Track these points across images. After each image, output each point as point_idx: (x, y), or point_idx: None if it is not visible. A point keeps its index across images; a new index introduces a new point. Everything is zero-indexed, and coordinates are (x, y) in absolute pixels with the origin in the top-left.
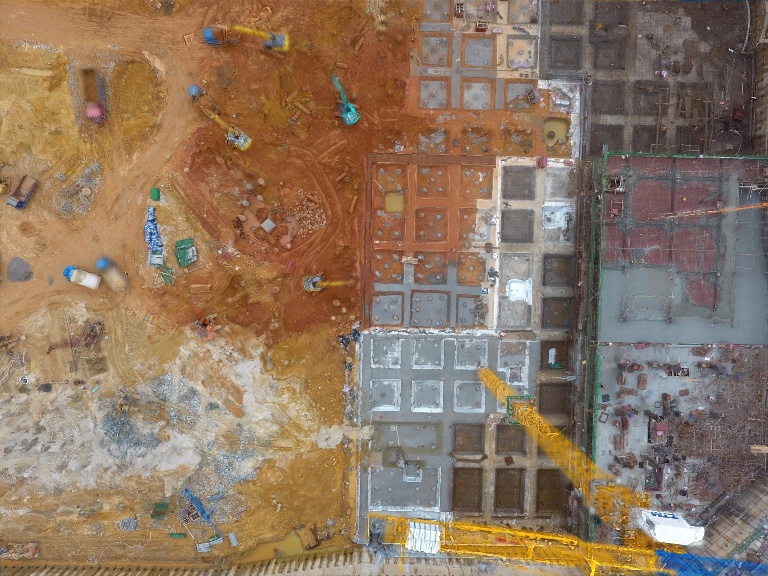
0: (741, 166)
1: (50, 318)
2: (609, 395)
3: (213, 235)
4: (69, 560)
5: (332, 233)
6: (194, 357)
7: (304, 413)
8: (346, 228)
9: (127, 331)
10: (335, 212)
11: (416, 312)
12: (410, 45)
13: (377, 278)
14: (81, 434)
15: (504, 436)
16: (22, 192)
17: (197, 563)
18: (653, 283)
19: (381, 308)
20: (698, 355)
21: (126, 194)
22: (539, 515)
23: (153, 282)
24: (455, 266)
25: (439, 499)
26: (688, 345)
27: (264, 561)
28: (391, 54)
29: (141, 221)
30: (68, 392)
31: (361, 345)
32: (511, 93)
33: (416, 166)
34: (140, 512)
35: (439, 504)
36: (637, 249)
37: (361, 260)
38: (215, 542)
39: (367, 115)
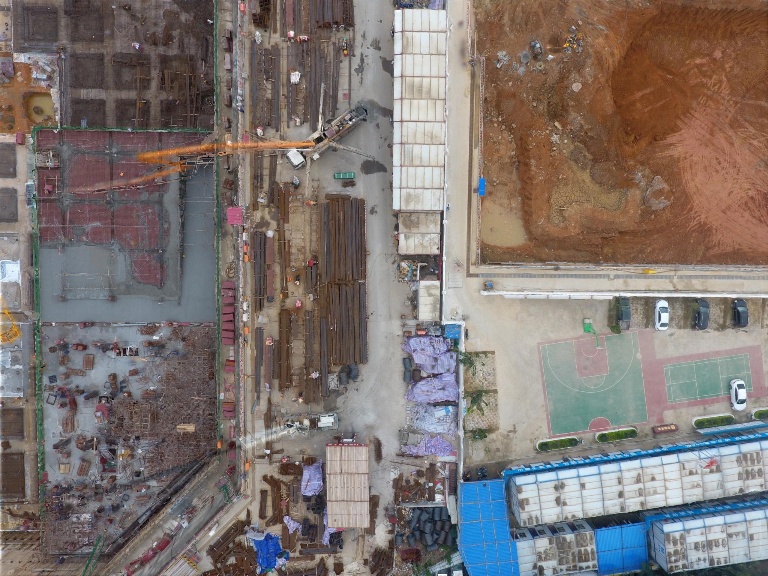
0: (181, 140)
1: None
2: (56, 376)
3: None
4: None
5: None
6: None
7: None
8: None
9: None
10: None
11: None
12: None
13: None
14: None
15: (3, 420)
16: None
17: None
18: (95, 261)
19: None
20: (146, 334)
21: None
22: None
23: None
24: None
25: None
26: (133, 324)
27: None
28: None
29: None
30: None
31: None
32: None
33: None
34: None
35: None
36: (76, 226)
37: None
38: None
39: None
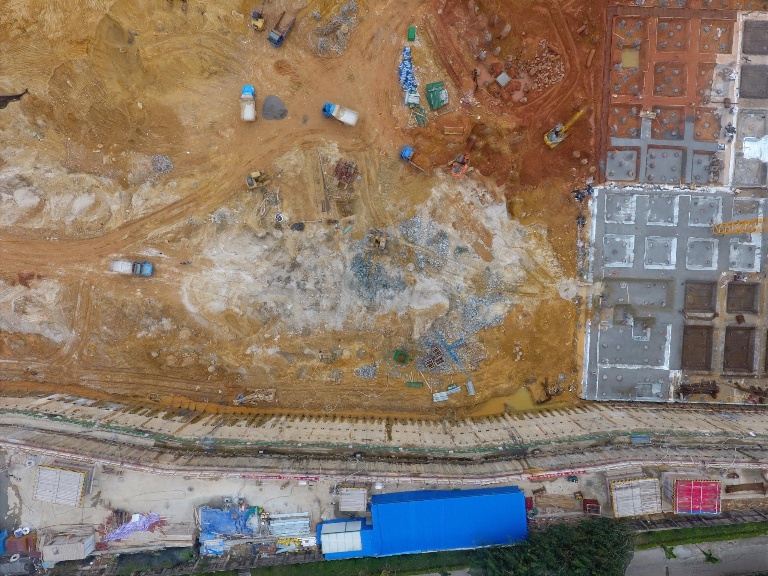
0: None
1: (303, 157)
2: None
3: (456, 83)
4: (304, 408)
5: (570, 86)
6: (446, 199)
7: (551, 259)
8: (584, 81)
9: (380, 172)
10: (574, 65)
11: (650, 168)
12: None
13: (612, 133)
14: (332, 274)
15: (734, 295)
16: (280, 28)
17: (430, 414)
18: None
19: (615, 164)
20: None
21: (381, 34)
22: None
23: (407, 123)
24: (692, 121)
25: (668, 357)
26: None
27: (495, 414)
28: None
29: (395, 61)
30: (323, 230)
31: (595, 200)
32: None
33: (657, 19)
34: (379, 359)
35: (668, 362)
36: None
37: (596, 115)
38: (453, 391)
39: None
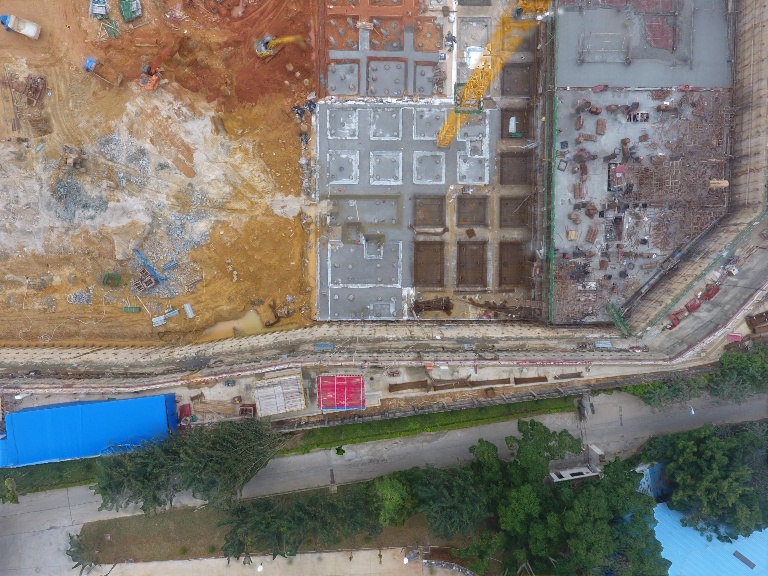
0: None
1: None
2: (568, 142)
3: None
4: (21, 339)
5: None
6: (141, 114)
7: (258, 174)
8: None
9: (71, 87)
10: None
11: (373, 82)
12: None
13: (332, 46)
14: (26, 195)
15: (465, 210)
16: None
17: (154, 340)
18: (611, 24)
19: (337, 78)
20: (657, 99)
21: None
22: (502, 288)
23: (96, 35)
24: (411, 31)
25: (400, 275)
26: (647, 88)
27: (223, 338)
28: None
29: None
30: (11, 149)
31: (317, 116)
32: None
33: None
34: (92, 284)
35: (401, 280)
36: None
37: (315, 28)
38: (171, 314)
39: None
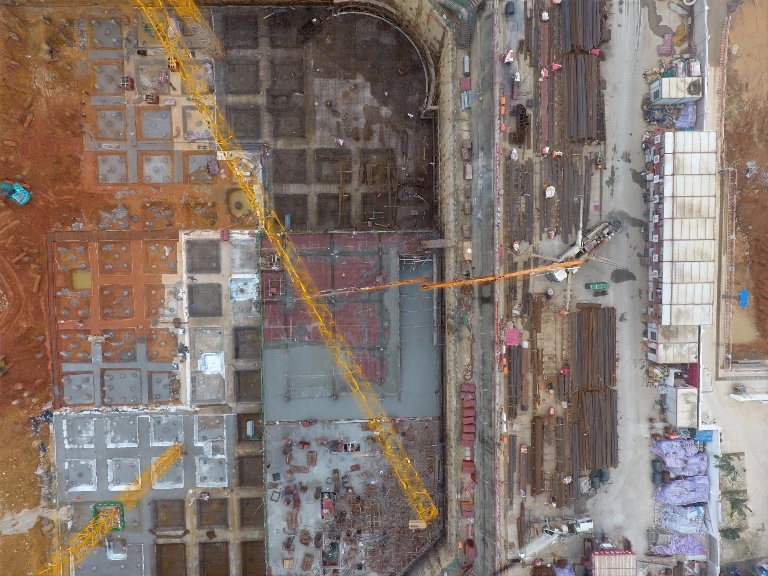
0: (400, 239)
1: None
2: (280, 474)
3: None
4: None
5: (15, 314)
6: None
7: None
8: (29, 309)
9: None
10: (16, 293)
11: (109, 390)
12: (82, 120)
13: (67, 357)
14: None
15: (207, 510)
16: None
17: None
18: (317, 360)
19: None
20: (367, 430)
21: None
22: None
23: None
24: (144, 343)
25: (143, 575)
26: (355, 421)
27: None
28: (61, 130)
29: None
30: None
31: (53, 426)
32: (192, 165)
33: (97, 243)
34: None
35: None
36: (299, 327)
37: (49, 340)
38: None
39: (41, 193)
